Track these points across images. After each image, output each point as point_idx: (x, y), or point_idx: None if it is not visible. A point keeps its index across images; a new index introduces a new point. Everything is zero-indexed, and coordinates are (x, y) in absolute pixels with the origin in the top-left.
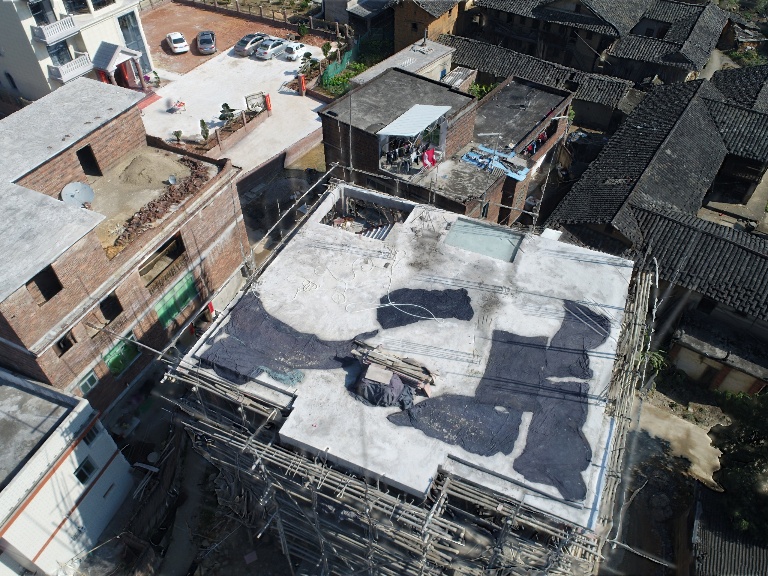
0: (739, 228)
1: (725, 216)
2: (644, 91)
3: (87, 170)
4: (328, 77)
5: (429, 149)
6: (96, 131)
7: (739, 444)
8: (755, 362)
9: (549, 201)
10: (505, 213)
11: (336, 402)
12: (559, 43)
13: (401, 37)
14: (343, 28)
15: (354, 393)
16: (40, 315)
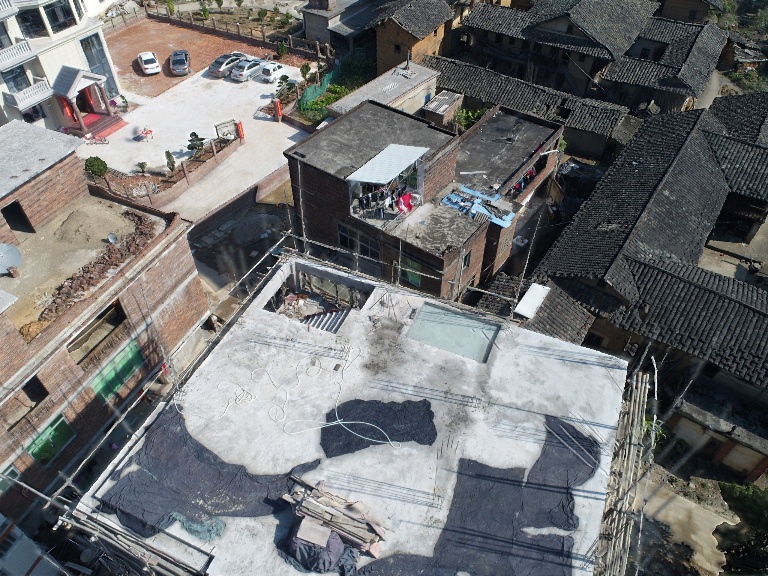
0: (742, 270)
1: (727, 256)
2: (640, 117)
3: (19, 226)
4: (306, 101)
5: (406, 192)
6: (25, 185)
7: (749, 547)
8: (763, 436)
9: (538, 242)
10: (489, 260)
11: (261, 566)
12: (550, 65)
13: (384, 59)
14: (324, 48)
15: (284, 552)
16: None
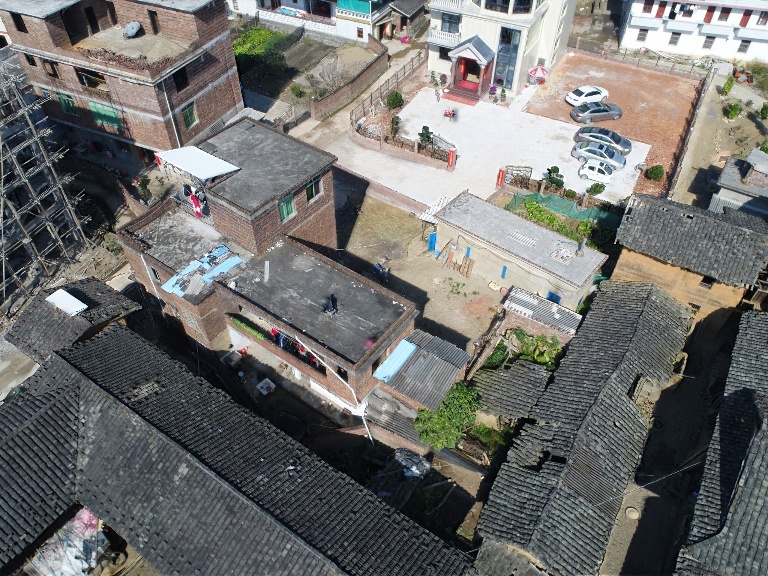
0: None
1: None
2: None
3: None
4: None
5: None
6: (162, 8)
7: None
8: None
9: None
10: None
11: None
12: None
13: None
14: None
15: None
16: (17, 34)
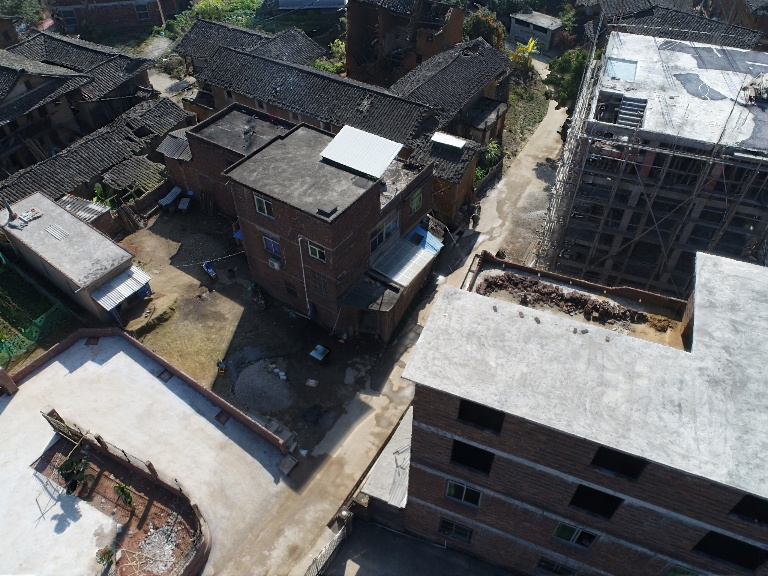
0: None
1: None
2: None
3: None
4: None
5: None
6: None
7: None
8: (496, 107)
9: None
10: None
11: None
12: (44, 127)
13: None
14: None
15: None
16: None
